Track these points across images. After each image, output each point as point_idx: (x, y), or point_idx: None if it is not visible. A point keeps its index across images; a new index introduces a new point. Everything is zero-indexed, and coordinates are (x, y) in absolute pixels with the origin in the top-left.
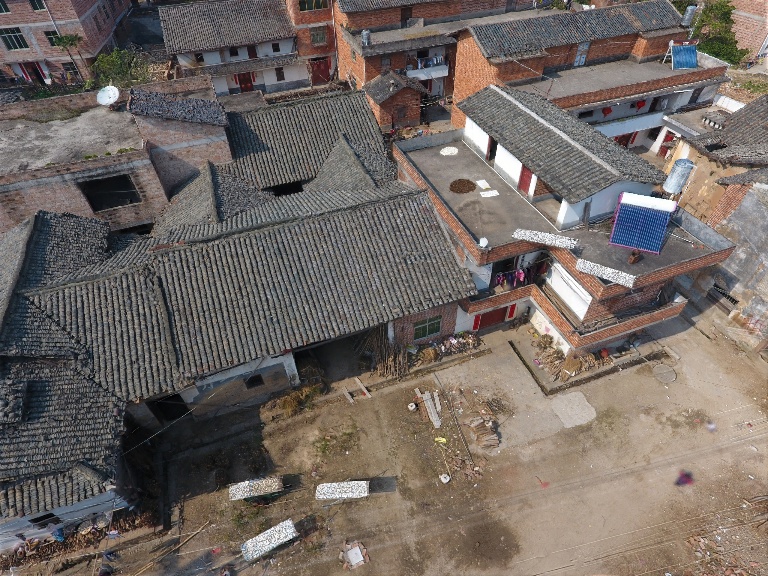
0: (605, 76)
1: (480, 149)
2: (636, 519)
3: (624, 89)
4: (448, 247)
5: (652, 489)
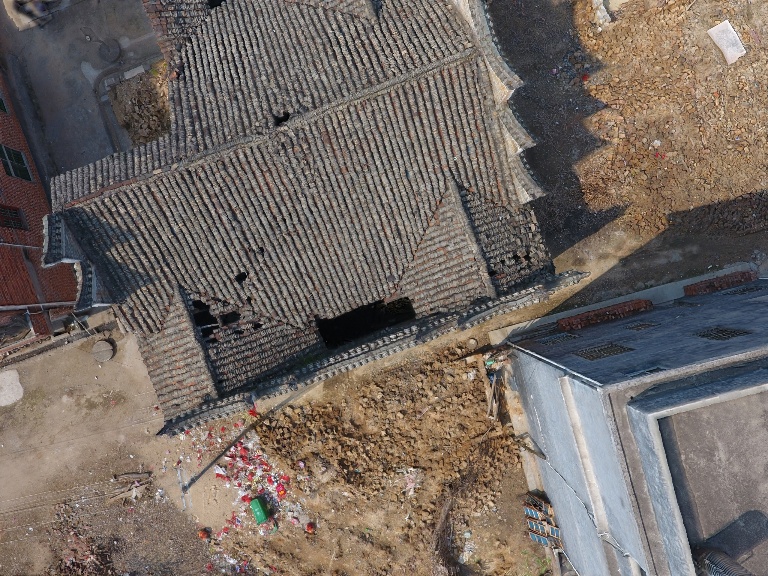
0: None
1: None
2: (23, 489)
3: None
4: None
5: (45, 466)
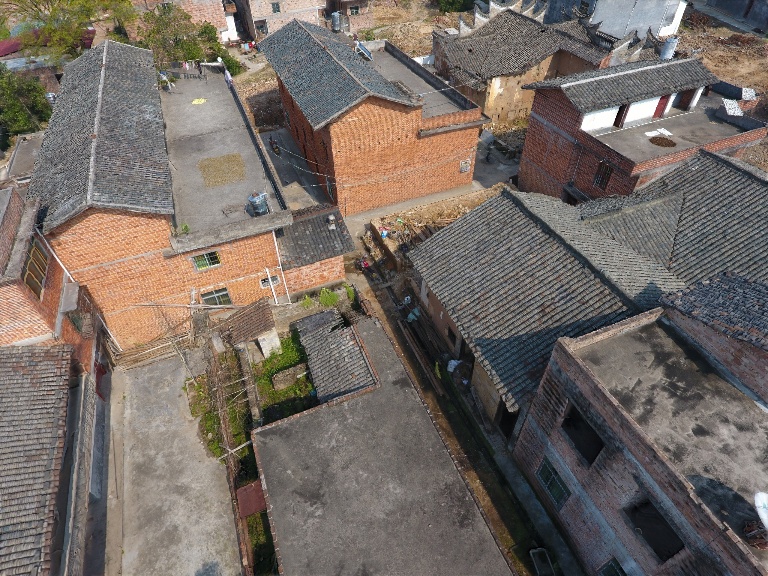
0: None
1: (604, 128)
2: None
3: None
4: None
5: None
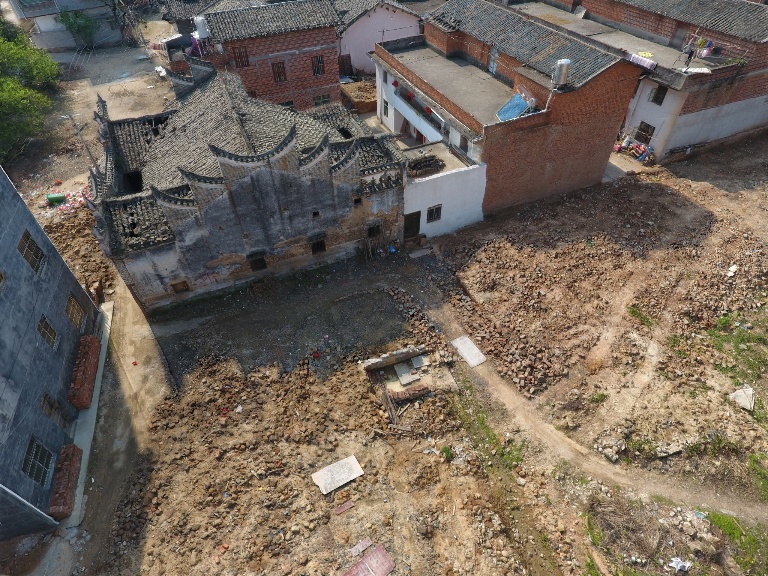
0: (467, 82)
1: None
2: None
3: None
4: None
5: None
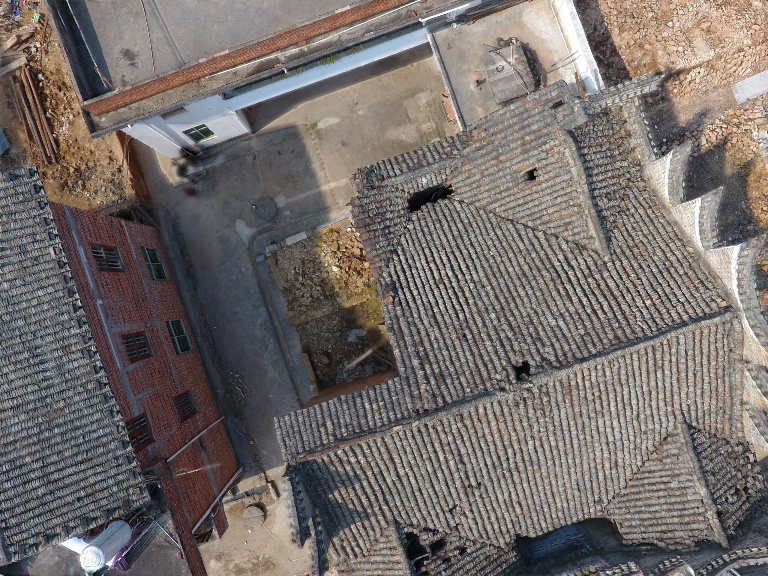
0: None
1: None
2: None
3: (299, 31)
4: None
5: None
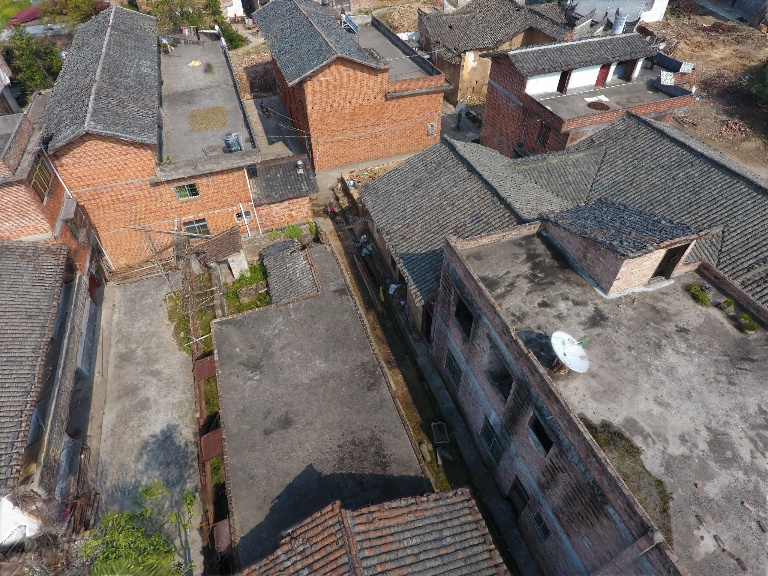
0: None
1: (548, 93)
2: None
3: None
4: (660, 124)
5: None
